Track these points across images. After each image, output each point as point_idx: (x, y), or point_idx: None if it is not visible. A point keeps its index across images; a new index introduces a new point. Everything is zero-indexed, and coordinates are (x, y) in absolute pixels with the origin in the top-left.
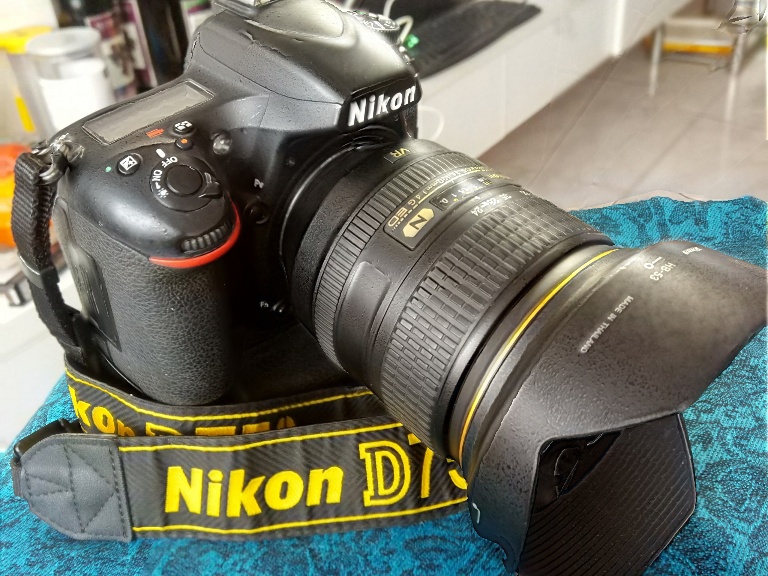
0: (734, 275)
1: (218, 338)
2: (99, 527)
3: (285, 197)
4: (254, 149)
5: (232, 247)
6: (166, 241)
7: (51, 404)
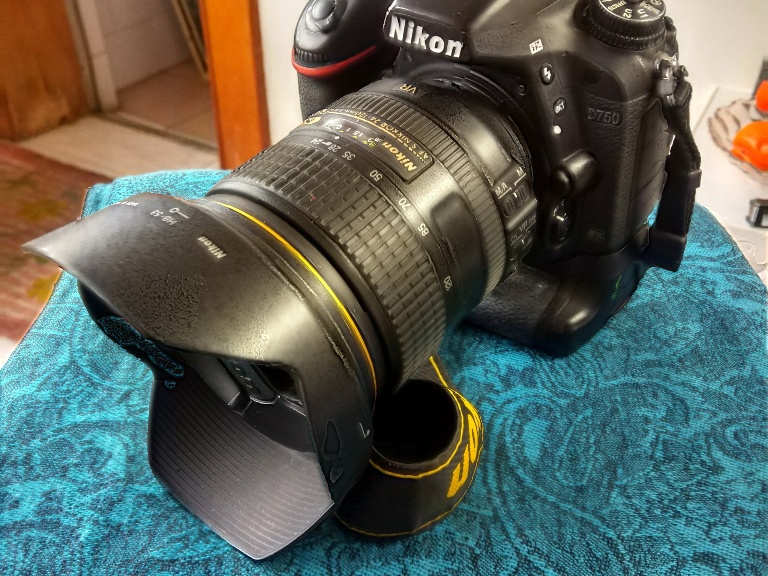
0: (149, 260)
1: None
2: None
3: None
4: None
5: (318, 76)
6: None
7: None
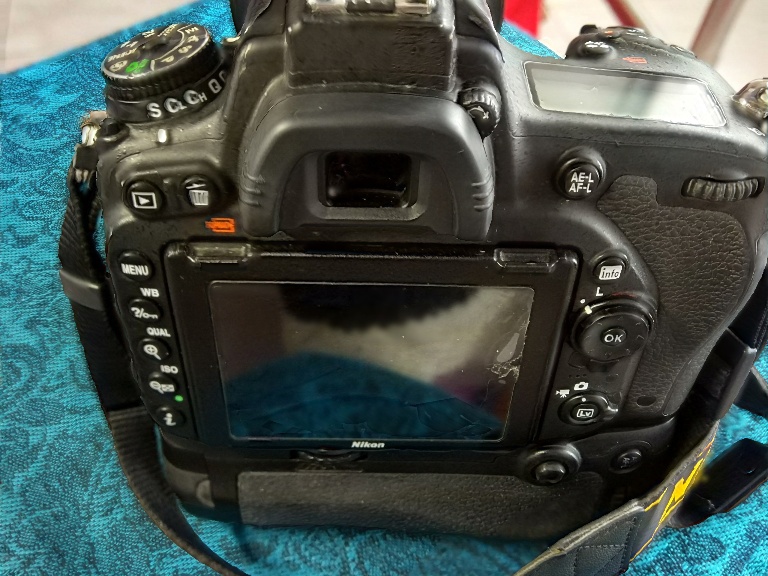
0: None
1: None
2: None
3: None
4: None
5: None
6: None
7: None
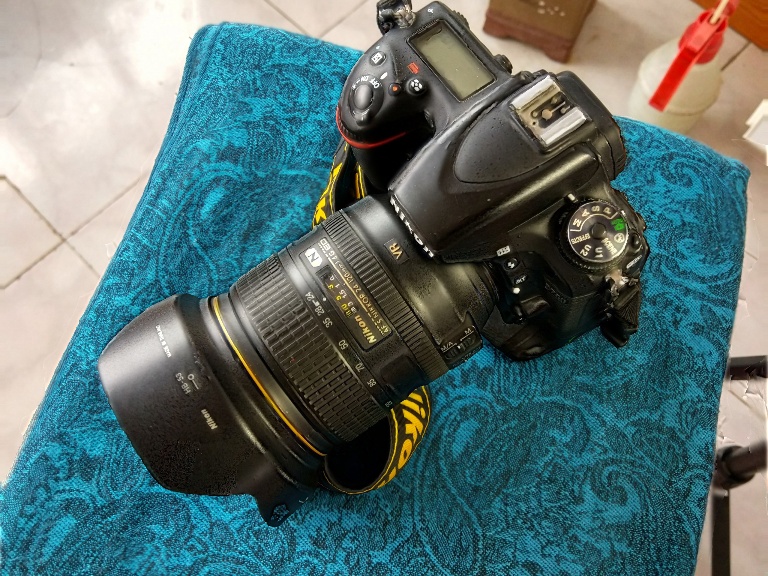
0: (168, 428)
1: (362, 164)
2: None
3: None
4: None
5: None
6: None
7: None
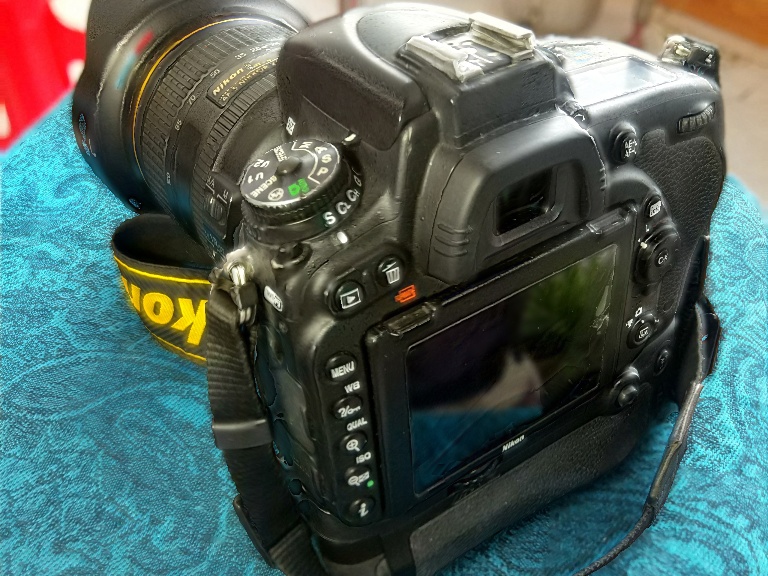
0: None
1: None
2: None
3: None
4: None
5: None
6: None
7: (748, 458)
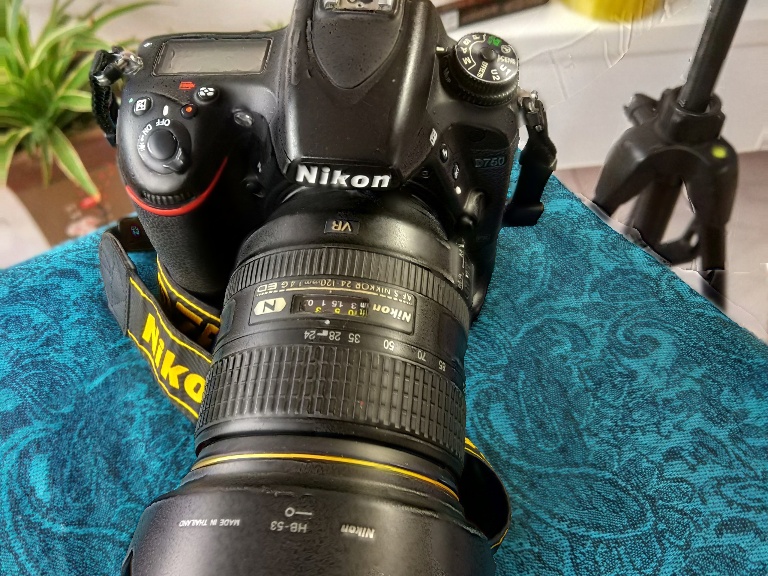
0: None
1: (190, 260)
2: (117, 312)
3: (281, 189)
4: (266, 138)
5: (185, 213)
6: (133, 183)
7: None
